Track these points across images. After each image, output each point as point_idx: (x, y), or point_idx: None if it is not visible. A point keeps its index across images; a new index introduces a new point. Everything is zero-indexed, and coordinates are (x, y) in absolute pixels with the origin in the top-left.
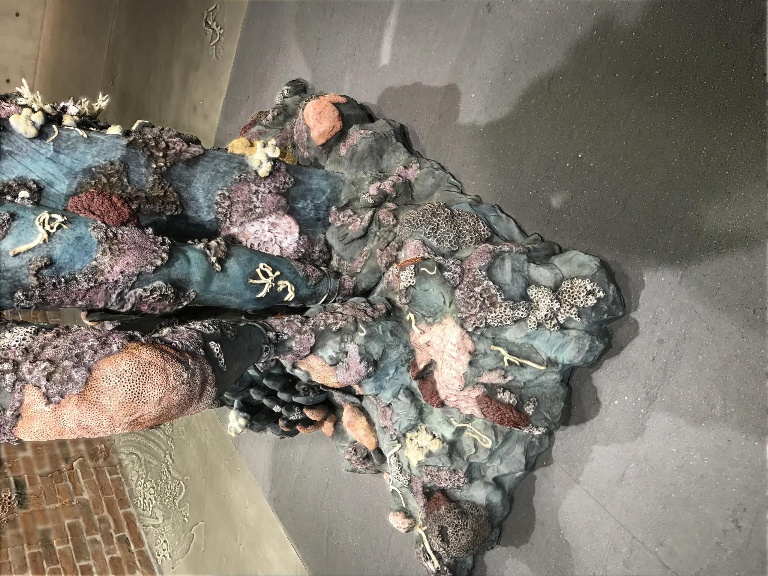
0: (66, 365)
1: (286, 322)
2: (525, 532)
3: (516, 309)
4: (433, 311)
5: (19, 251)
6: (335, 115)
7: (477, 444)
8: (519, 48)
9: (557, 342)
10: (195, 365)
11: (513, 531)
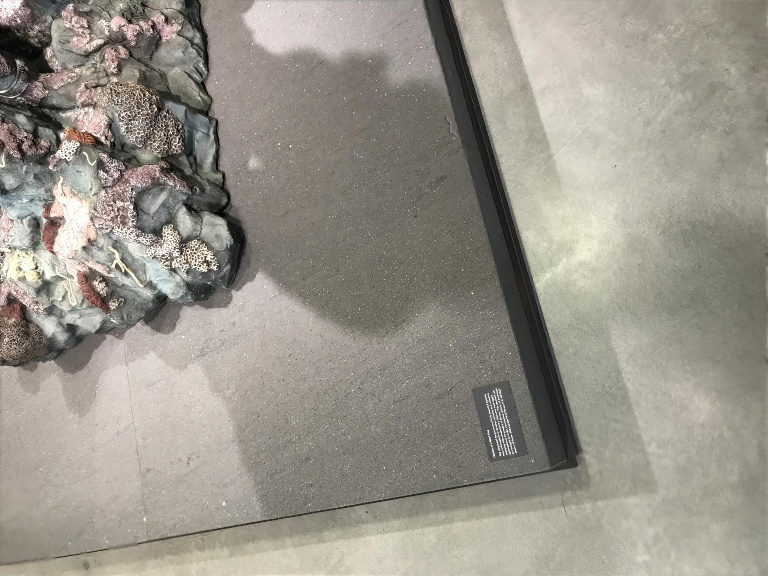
0: None
1: None
2: (75, 367)
3: (142, 236)
4: (77, 189)
5: None
6: None
7: (66, 296)
8: (323, 7)
9: (163, 276)
10: None
11: (69, 359)
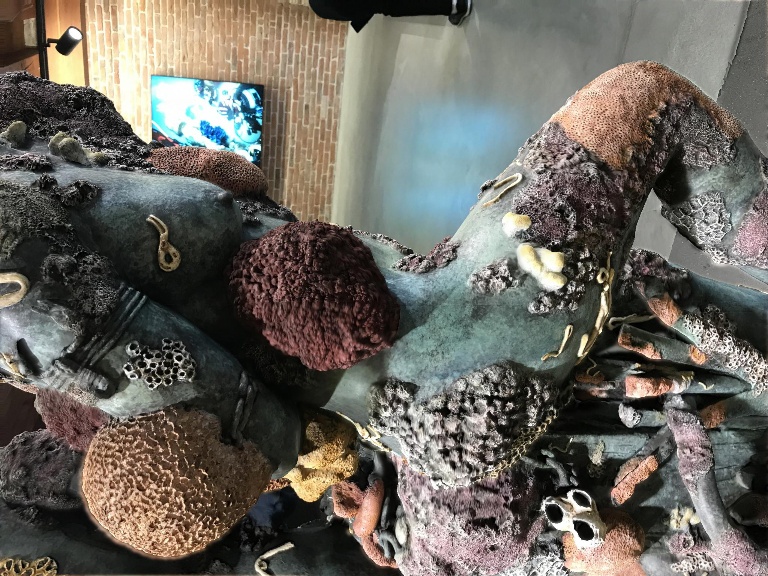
0: None
1: None
2: None
3: None
4: None
5: None
6: None
7: None
8: None
9: None
10: None
11: None
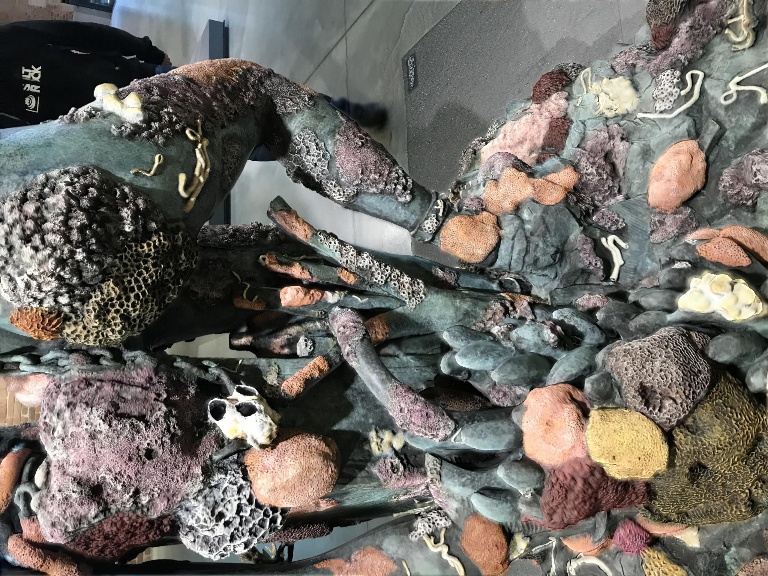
0: None
1: None
2: None
3: None
4: None
5: None
6: None
7: None
8: None
9: None
10: None
11: None
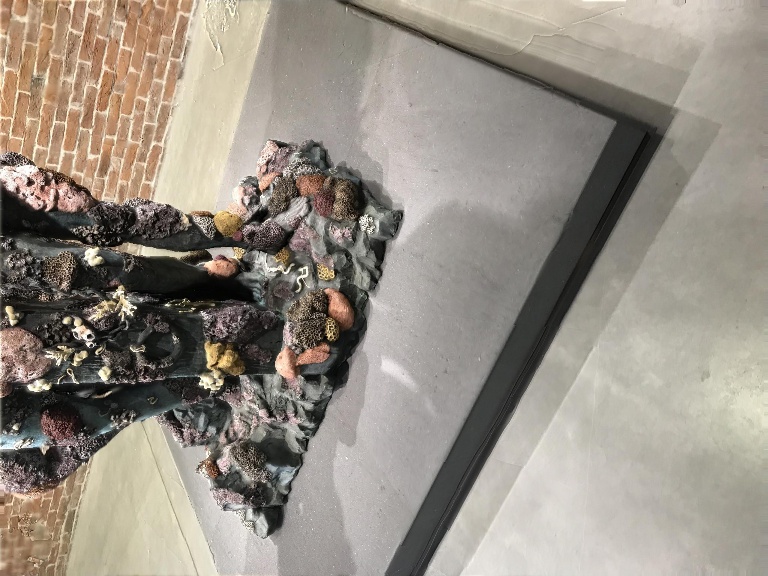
0: (4, 486)
1: (156, 417)
2: None
3: None
4: None
5: None
6: None
7: None
8: (358, 506)
9: None
10: None
11: None
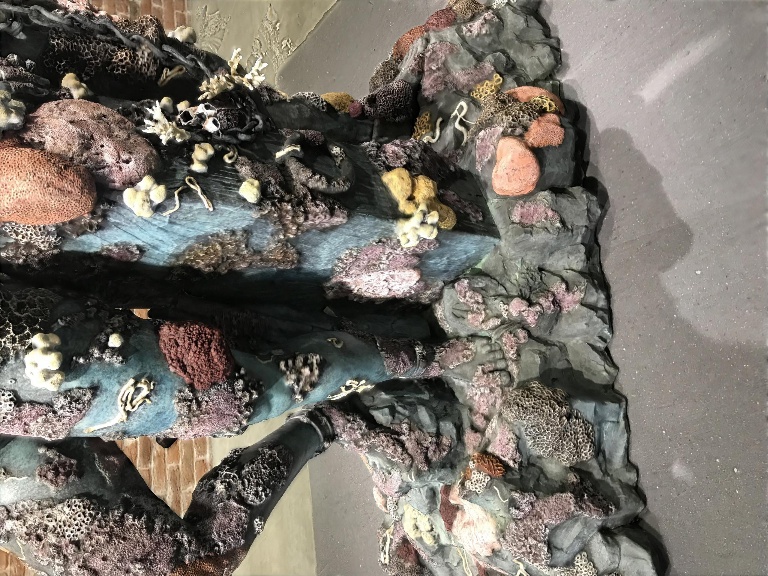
0: None
1: (348, 428)
2: None
3: None
4: None
5: (94, 429)
6: (532, 180)
7: (461, 563)
8: None
9: None
10: (229, 571)
11: None
